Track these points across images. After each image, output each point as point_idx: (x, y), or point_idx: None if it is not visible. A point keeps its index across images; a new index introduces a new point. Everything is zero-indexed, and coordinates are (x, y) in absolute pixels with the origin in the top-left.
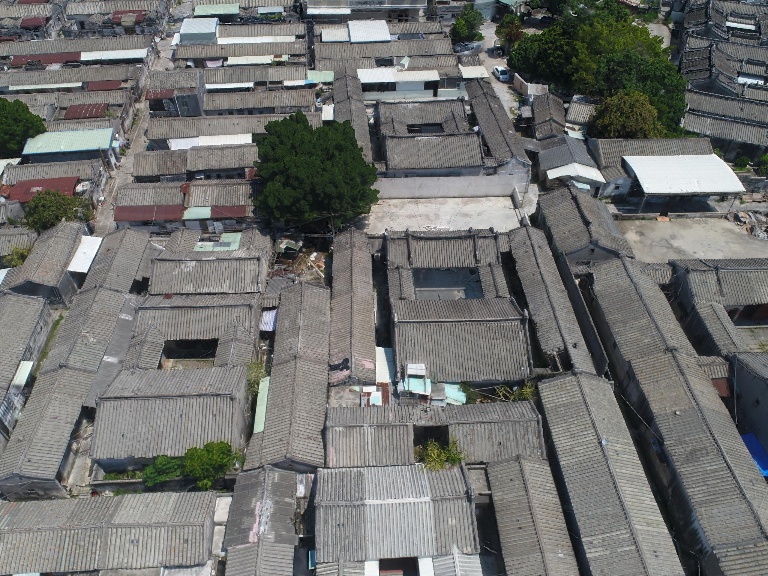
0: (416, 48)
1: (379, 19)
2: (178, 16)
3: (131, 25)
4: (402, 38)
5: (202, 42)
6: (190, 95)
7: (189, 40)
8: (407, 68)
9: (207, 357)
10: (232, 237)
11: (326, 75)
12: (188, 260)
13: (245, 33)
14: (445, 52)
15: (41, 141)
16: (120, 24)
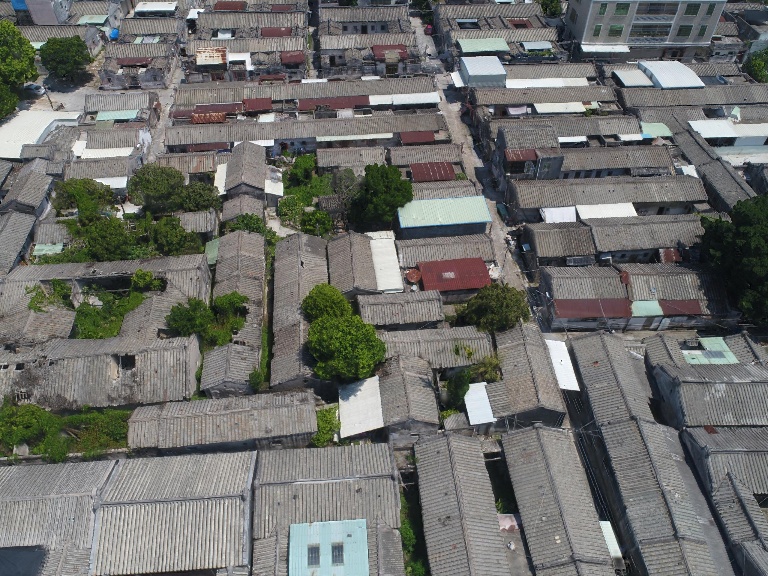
0: (733, 95)
1: (664, 58)
2: (419, 49)
3: (395, 62)
4: (702, 81)
5: (489, 84)
6: (557, 157)
7: (476, 82)
8: (741, 120)
9: (767, 506)
10: (716, 344)
11: (660, 128)
12: (717, 382)
13: (532, 74)
14: (765, 100)
15: (413, 211)
16: (384, 61)
